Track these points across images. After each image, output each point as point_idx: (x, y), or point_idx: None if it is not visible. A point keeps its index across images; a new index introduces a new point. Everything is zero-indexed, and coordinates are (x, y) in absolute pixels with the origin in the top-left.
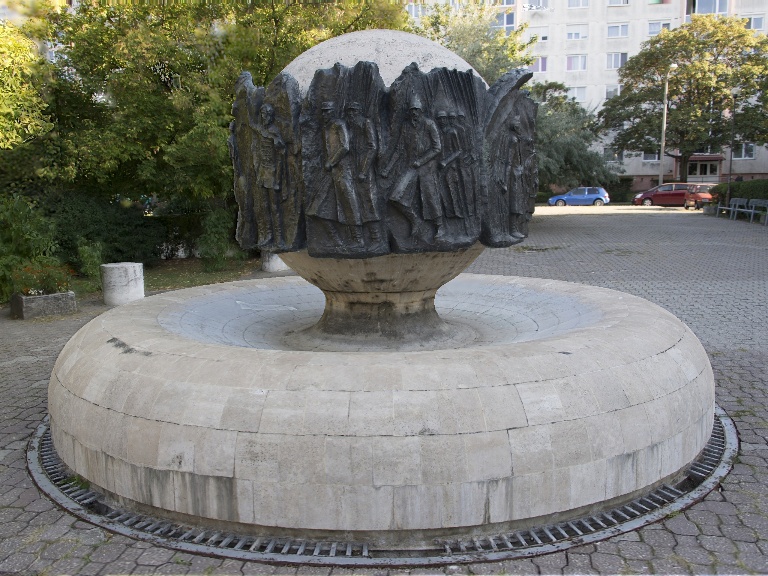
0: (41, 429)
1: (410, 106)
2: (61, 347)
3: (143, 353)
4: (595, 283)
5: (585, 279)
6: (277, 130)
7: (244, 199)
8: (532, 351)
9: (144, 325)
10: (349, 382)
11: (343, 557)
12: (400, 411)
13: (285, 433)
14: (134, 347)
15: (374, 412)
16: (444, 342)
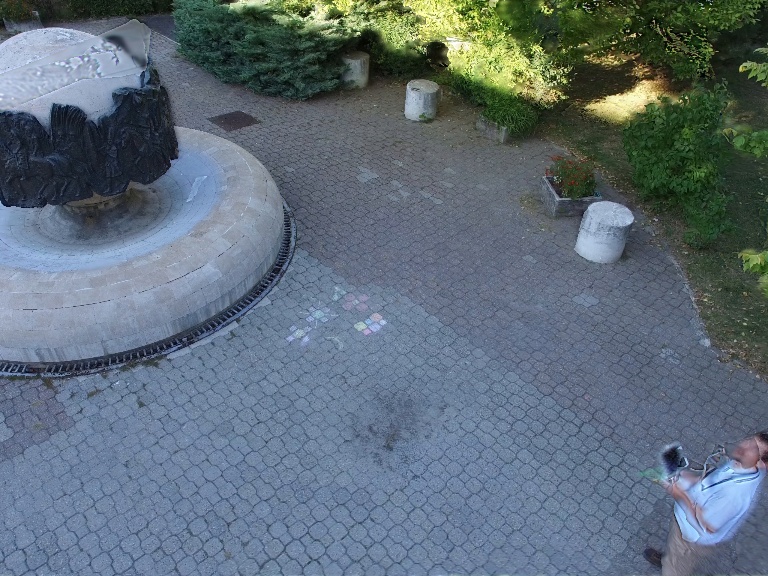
0: None
1: None
2: (389, 188)
3: None
4: None
5: None
6: None
7: None
8: None
9: None
10: None
11: None
12: None
13: None
14: None
15: None
16: (50, 212)
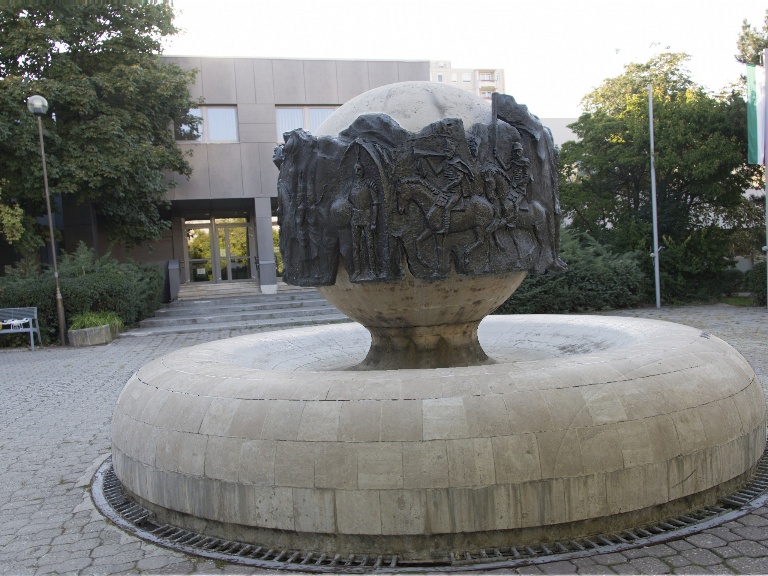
0: (759, 501)
1: None
2: None
3: None
4: None
5: None
6: None
7: None
8: None
9: None
10: None
11: None
12: None
13: None
14: None
15: None
16: None
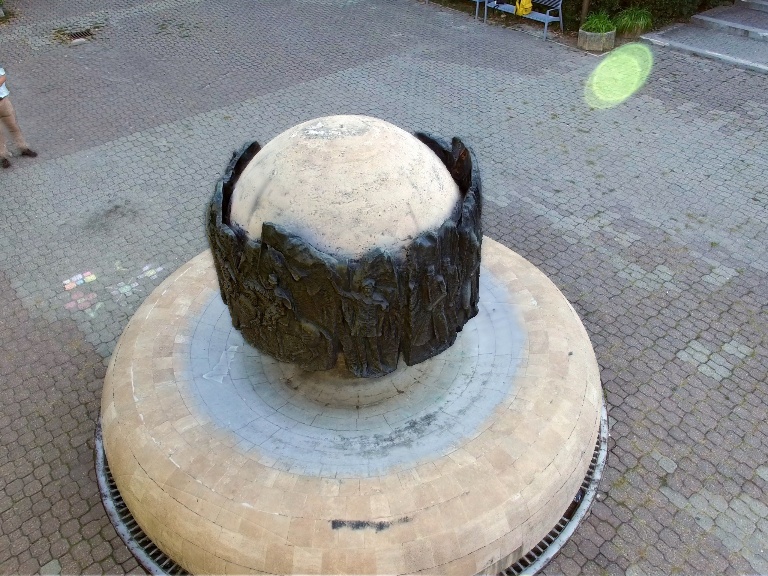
0: None
1: (473, 242)
2: None
3: (401, 521)
4: (238, 110)
5: (219, 103)
6: (381, 296)
7: (329, 345)
8: (563, 364)
9: (305, 488)
10: (547, 457)
11: (564, 530)
12: (573, 454)
13: (542, 507)
14: (380, 521)
15: (567, 464)
16: None
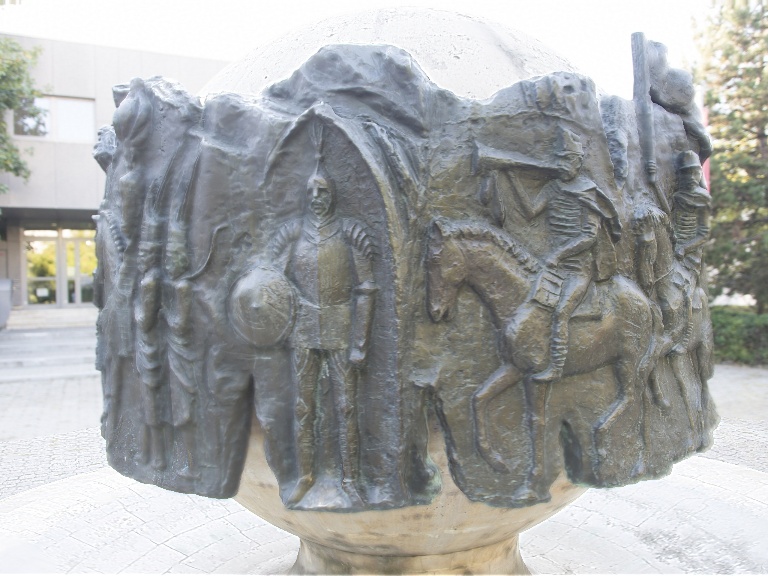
0: None
1: None
2: None
3: None
4: None
5: None
6: None
7: None
8: None
9: None
10: None
11: None
12: None
13: None
14: None
15: None
16: None
